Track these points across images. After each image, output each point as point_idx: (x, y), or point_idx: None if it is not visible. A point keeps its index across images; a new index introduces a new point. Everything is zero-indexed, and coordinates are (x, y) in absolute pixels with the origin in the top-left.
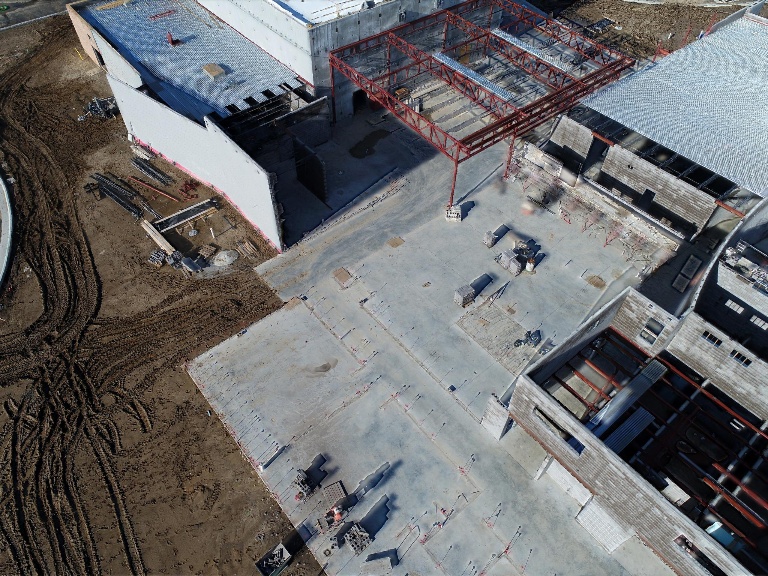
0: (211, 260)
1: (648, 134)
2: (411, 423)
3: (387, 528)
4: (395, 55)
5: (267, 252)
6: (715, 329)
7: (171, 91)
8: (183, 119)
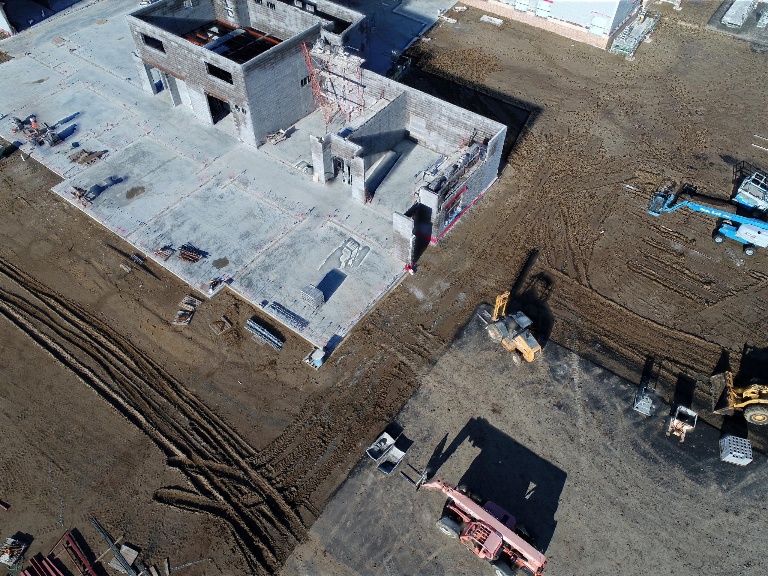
0: None
1: None
2: (97, 96)
3: (73, 135)
4: None
5: (2, 37)
6: None
7: None
8: None
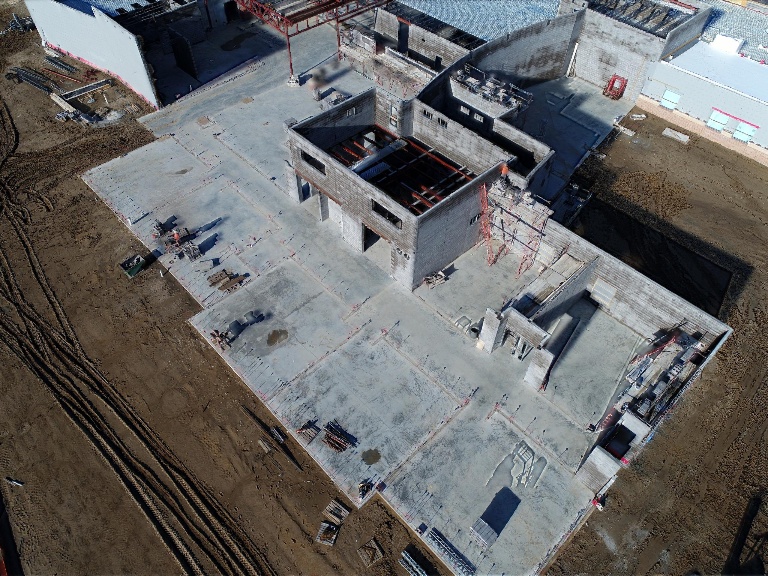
0: (104, 117)
1: (438, 17)
2: (240, 197)
3: (214, 249)
4: None
5: (148, 110)
6: (427, 106)
7: (73, 1)
8: (78, 13)
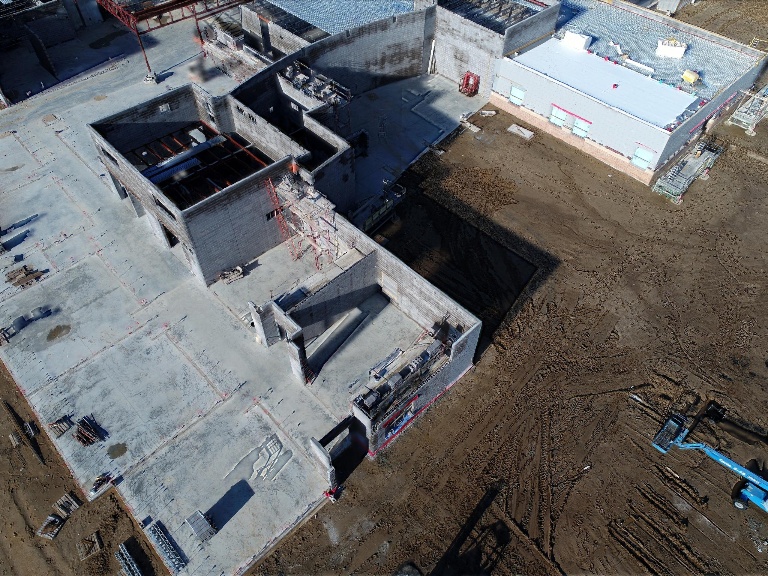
0: None
1: (298, 14)
2: (64, 194)
3: (21, 245)
4: None
5: None
6: (238, 102)
7: None
8: None
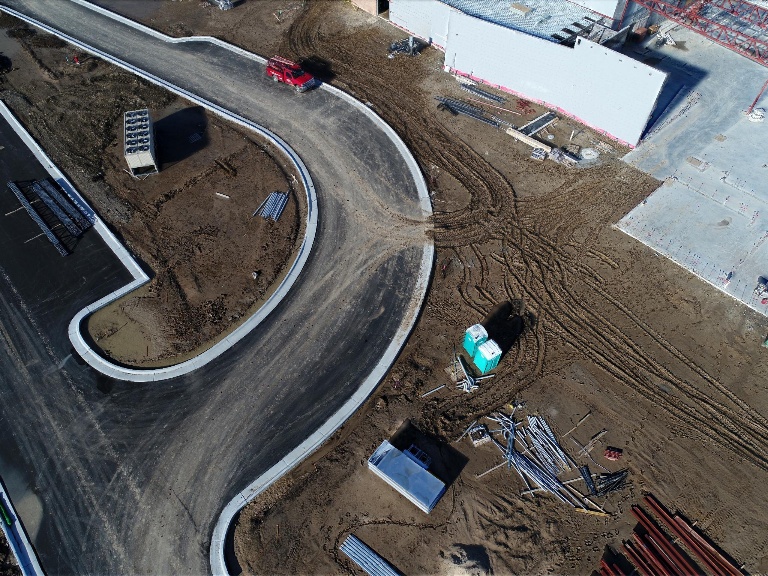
0: (580, 155)
1: None
2: None
3: None
4: None
5: (621, 148)
6: None
7: None
8: (544, 42)
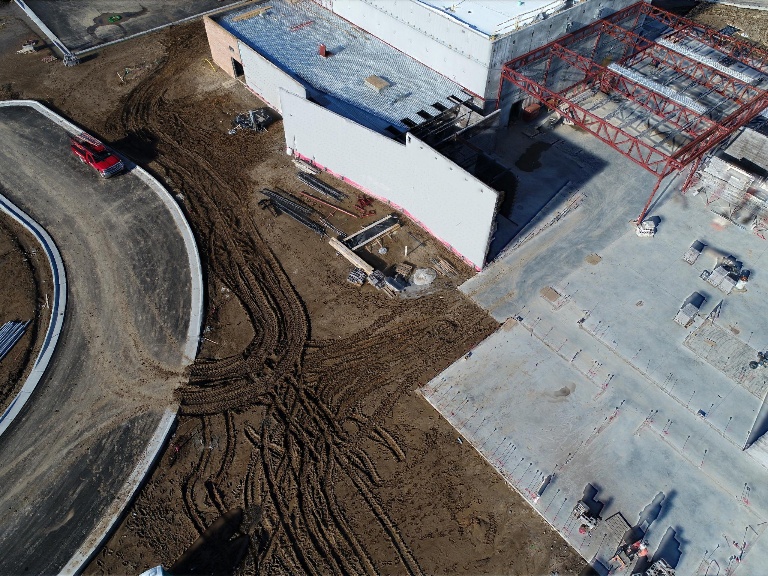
0: (410, 279)
1: None
2: (672, 450)
3: (684, 563)
4: (553, 66)
5: (465, 270)
6: None
7: (339, 104)
8: (375, 134)
